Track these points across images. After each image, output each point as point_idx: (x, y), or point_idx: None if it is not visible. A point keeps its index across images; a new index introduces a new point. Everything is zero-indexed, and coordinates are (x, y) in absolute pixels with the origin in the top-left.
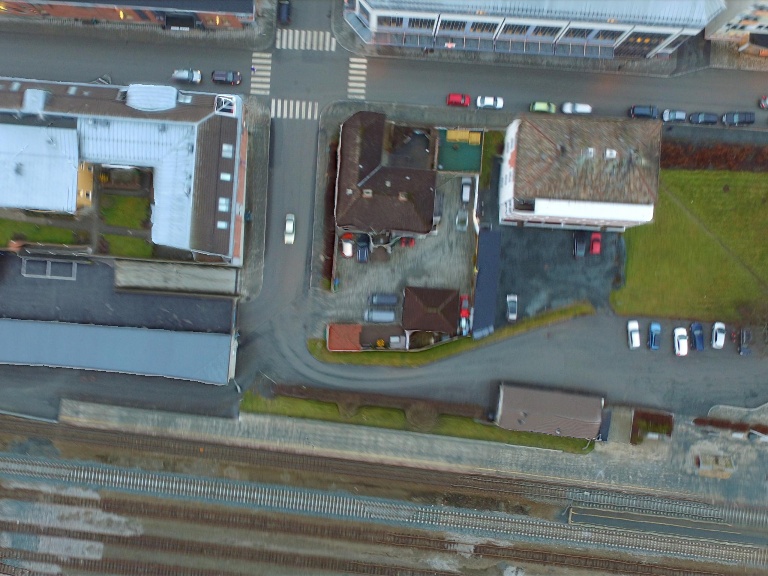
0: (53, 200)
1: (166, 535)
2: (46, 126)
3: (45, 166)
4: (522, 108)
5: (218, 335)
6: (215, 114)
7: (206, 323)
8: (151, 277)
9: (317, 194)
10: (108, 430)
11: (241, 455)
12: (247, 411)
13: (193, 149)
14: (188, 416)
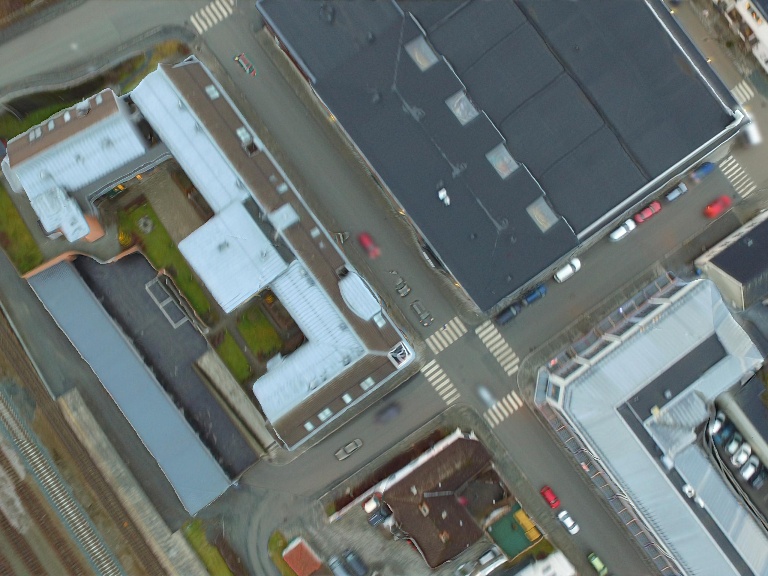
0: (221, 290)
1: (37, 552)
2: (272, 243)
3: (242, 263)
4: (585, 548)
5: (224, 476)
6: (387, 356)
7: (225, 452)
8: (225, 380)
9: (392, 449)
10: (81, 443)
11: (147, 557)
12: (184, 534)
13: (347, 364)
14: (143, 494)
